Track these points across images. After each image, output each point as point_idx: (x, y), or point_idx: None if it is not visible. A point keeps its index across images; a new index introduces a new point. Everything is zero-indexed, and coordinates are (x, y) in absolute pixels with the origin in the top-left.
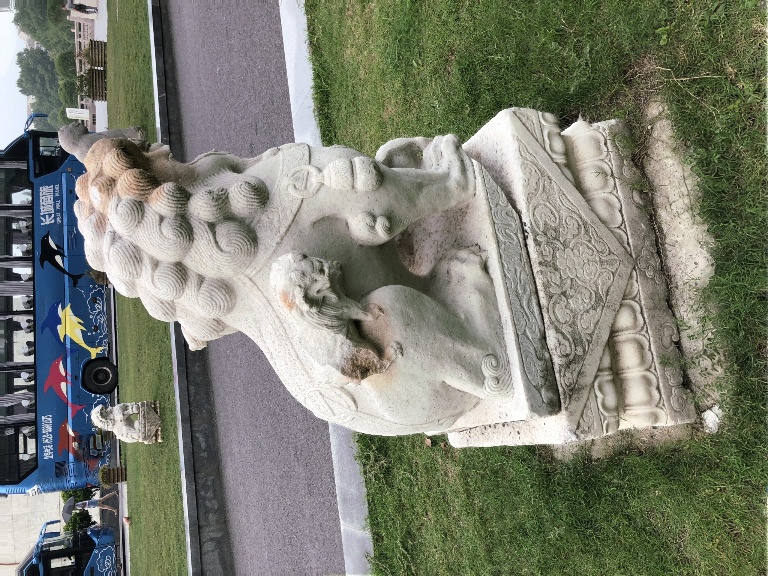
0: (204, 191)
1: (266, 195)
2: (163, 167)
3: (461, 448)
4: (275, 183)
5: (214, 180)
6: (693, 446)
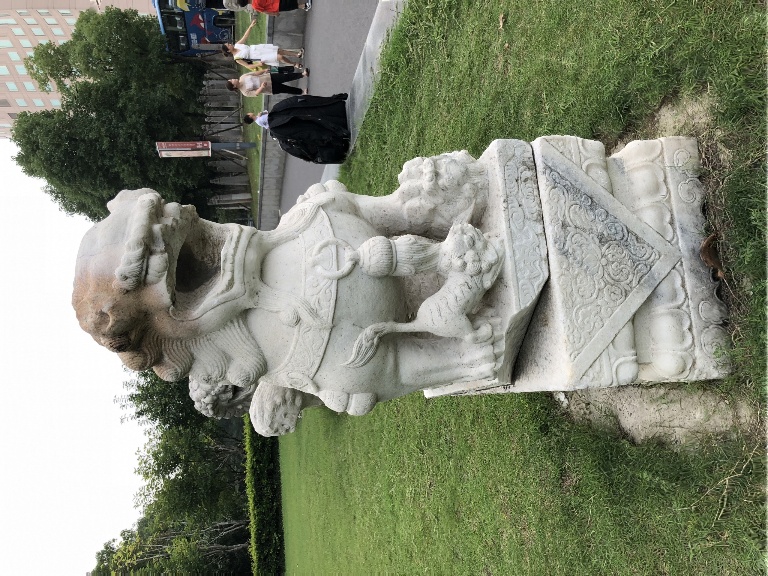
0: (202, 379)
1: (264, 373)
2: (163, 331)
3: (511, 82)
4: (276, 368)
5: (218, 337)
6: (538, 392)
